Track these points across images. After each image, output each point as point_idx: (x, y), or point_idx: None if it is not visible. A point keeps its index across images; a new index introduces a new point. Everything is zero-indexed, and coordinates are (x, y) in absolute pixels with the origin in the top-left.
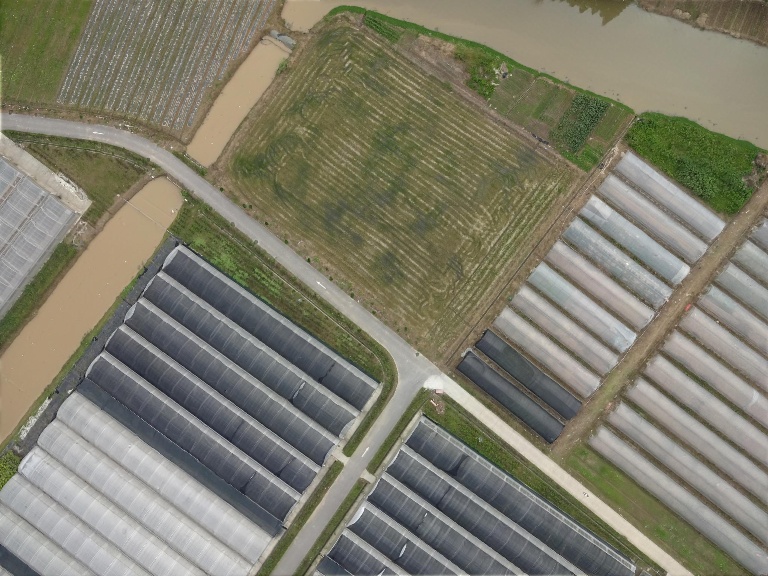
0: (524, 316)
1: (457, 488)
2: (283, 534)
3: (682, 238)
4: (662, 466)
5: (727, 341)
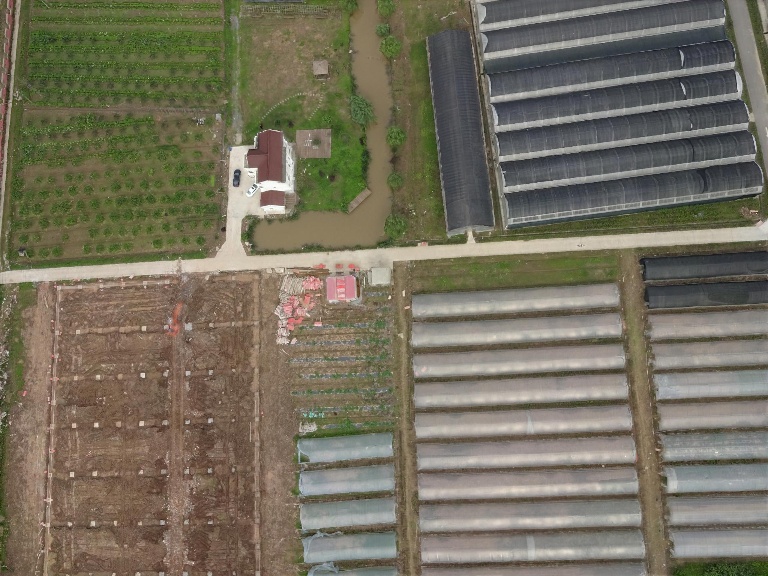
0: (754, 338)
1: (687, 164)
2: (764, 28)
3: (694, 514)
4: (546, 315)
5: (583, 456)
